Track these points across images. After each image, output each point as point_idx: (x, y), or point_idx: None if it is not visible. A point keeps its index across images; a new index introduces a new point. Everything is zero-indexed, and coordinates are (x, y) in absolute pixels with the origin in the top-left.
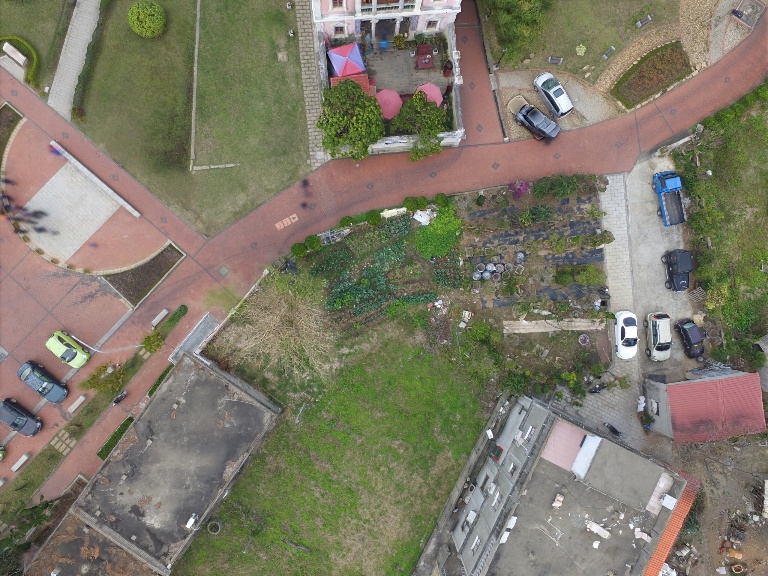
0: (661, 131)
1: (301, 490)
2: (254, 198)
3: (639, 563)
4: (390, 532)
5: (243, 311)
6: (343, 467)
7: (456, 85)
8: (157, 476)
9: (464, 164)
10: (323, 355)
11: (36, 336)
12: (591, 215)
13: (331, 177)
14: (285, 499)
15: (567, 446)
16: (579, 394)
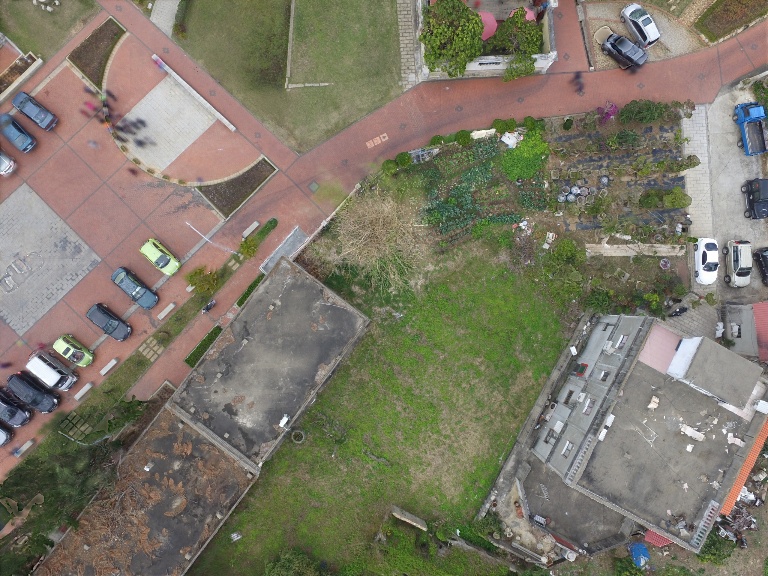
0: (742, 65)
1: (384, 403)
2: (346, 117)
3: (733, 467)
4: (470, 448)
5: (333, 224)
6: (425, 382)
7: (550, 9)
8: (251, 376)
9: (551, 90)
10: (409, 271)
11: (129, 244)
12: (674, 143)
13: (421, 99)
14: (368, 411)
15: (663, 350)
16: (660, 317)
